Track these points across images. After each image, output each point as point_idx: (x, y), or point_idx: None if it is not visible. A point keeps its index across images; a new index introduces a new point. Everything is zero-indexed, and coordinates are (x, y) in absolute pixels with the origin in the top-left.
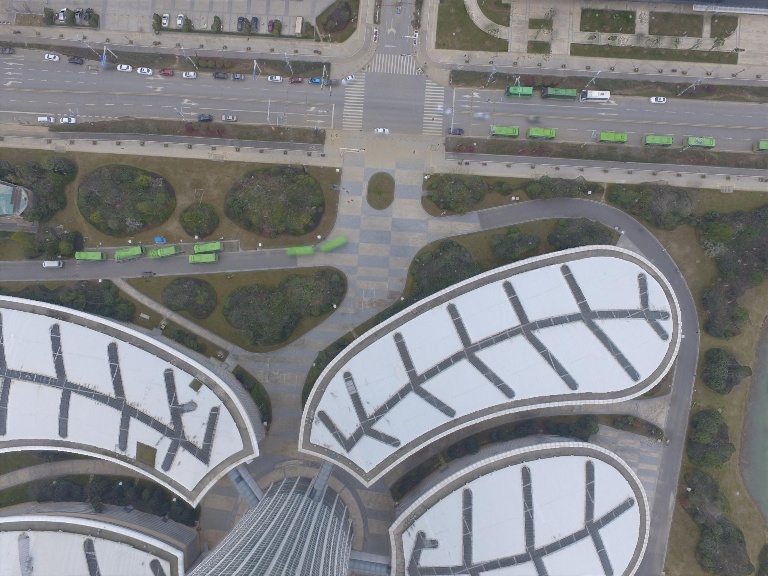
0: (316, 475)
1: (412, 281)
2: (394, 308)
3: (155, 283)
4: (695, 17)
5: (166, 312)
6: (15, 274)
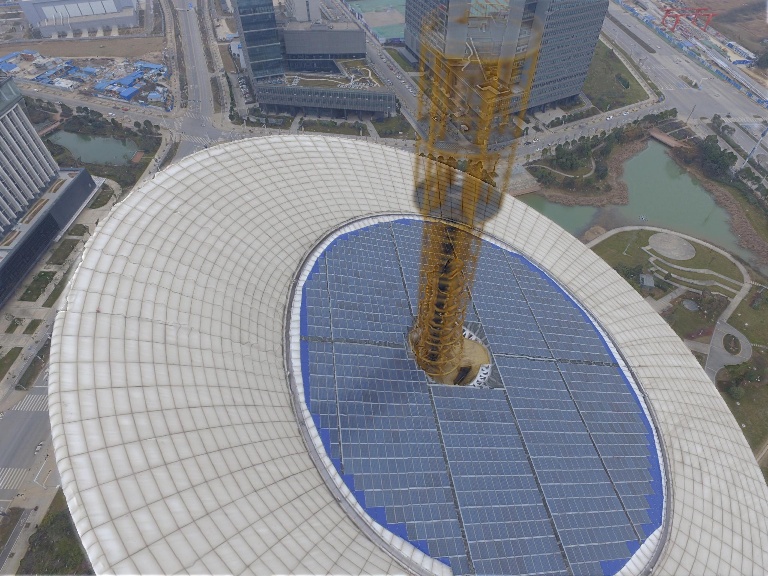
0: None
1: None
2: None
3: None
4: (64, 243)
5: None
6: None
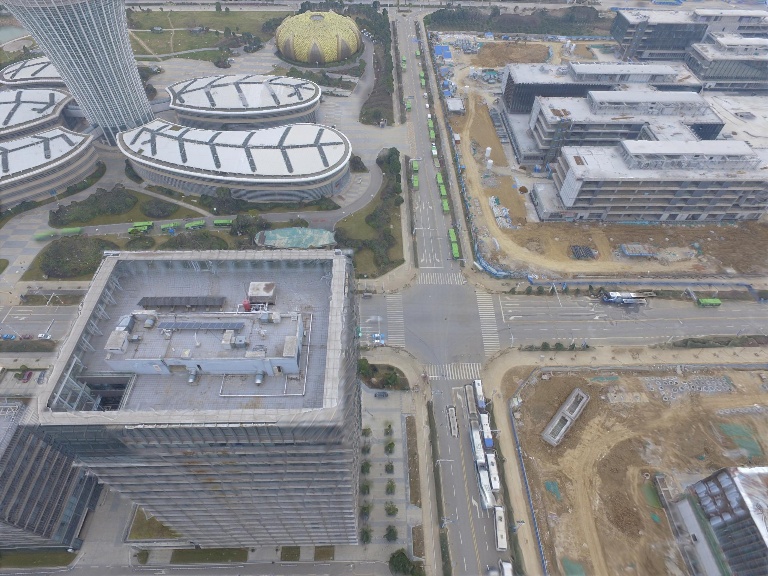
0: (109, 148)
1: (1, 222)
2: (21, 208)
3: (183, 215)
4: None
5: (180, 203)
6: (280, 216)
